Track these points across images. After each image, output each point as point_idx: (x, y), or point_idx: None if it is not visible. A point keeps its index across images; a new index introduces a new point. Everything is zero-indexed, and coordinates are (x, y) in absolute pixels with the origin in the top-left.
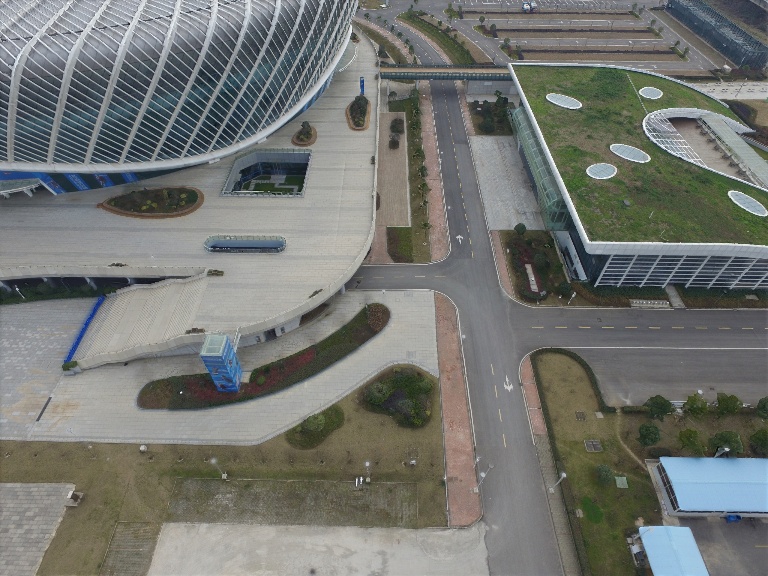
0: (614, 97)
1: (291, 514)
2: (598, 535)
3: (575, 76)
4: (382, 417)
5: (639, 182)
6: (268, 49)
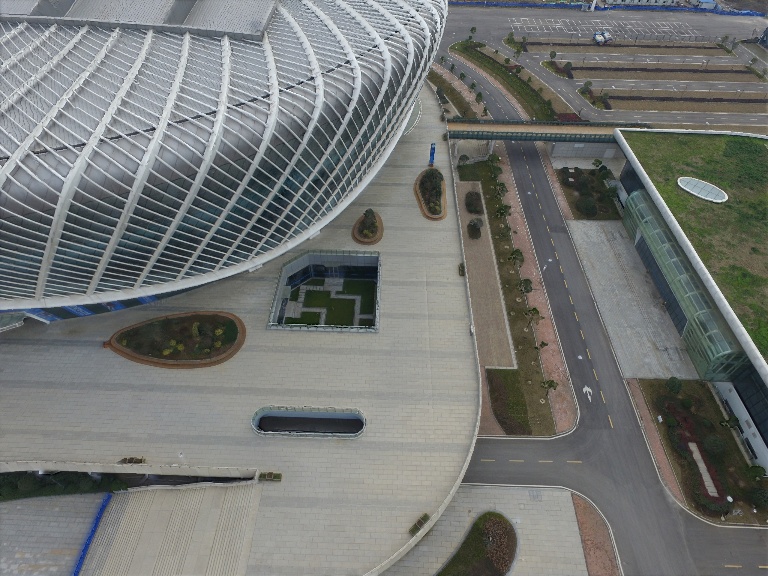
0: (763, 182)
1: None
2: None
3: (703, 148)
4: None
5: None
6: (339, 140)
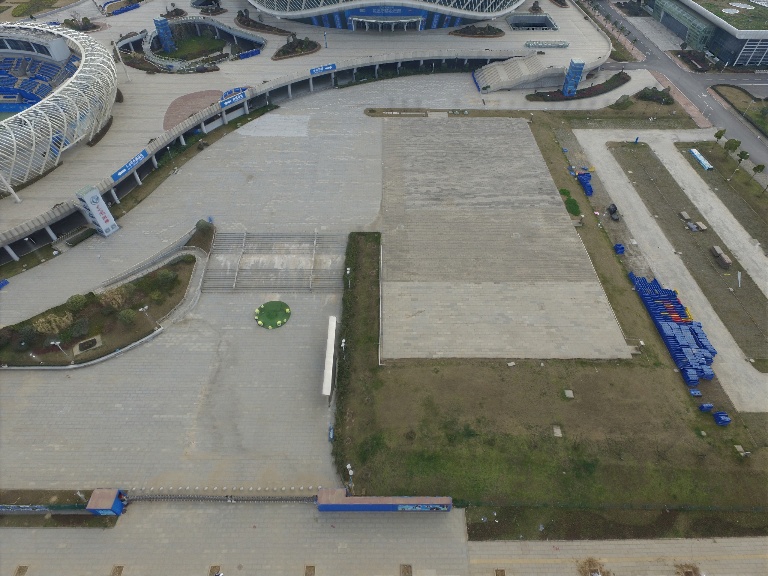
0: None
1: (626, 127)
2: (767, 128)
3: None
4: (651, 102)
5: (752, 15)
6: None
